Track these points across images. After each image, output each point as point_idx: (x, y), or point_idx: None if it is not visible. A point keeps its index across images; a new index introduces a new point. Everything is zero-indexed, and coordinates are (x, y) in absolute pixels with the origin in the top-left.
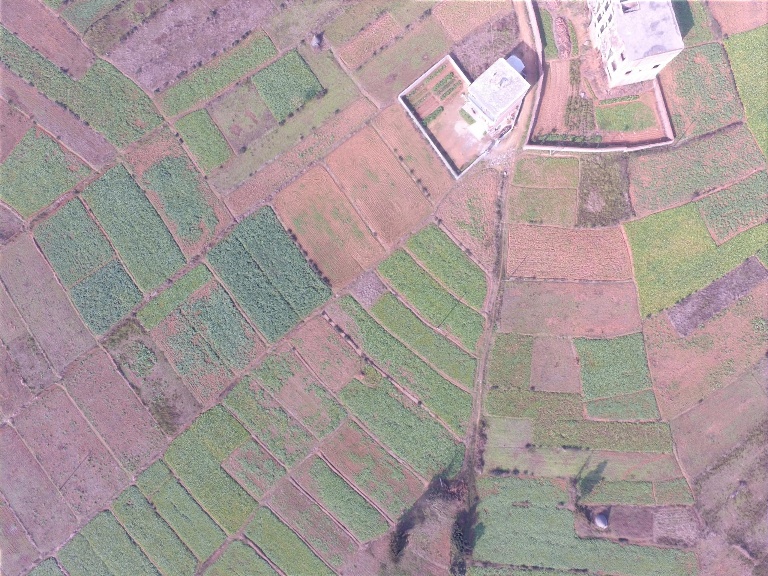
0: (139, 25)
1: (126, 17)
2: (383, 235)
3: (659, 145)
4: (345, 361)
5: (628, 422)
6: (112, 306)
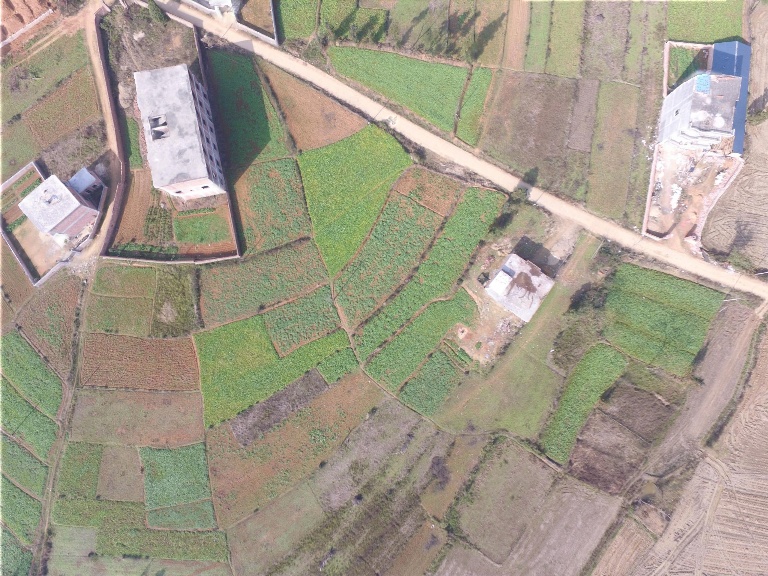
0: None
1: None
2: None
3: (228, 258)
4: None
5: (187, 531)
6: None
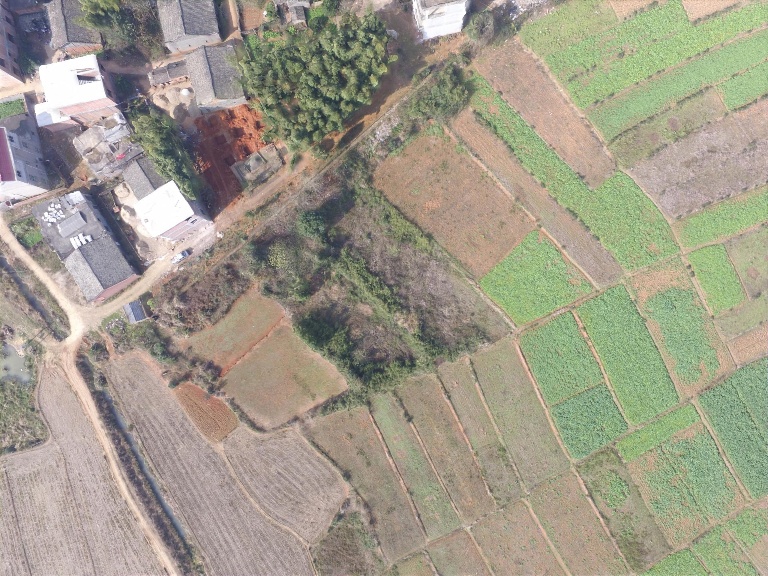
0: (670, 143)
1: (657, 132)
2: None
3: None
4: None
5: None
6: (595, 432)
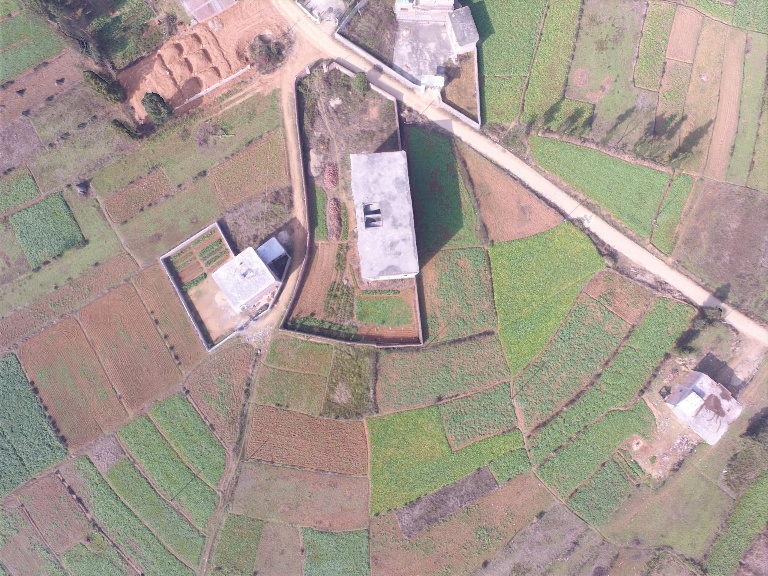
0: None
1: None
2: (128, 399)
3: (410, 345)
4: (73, 524)
5: None
6: None
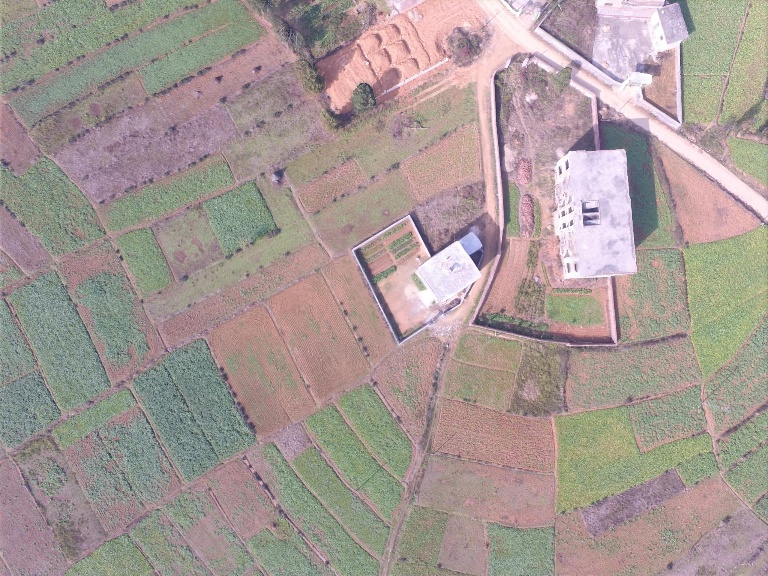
0: (92, 128)
1: (79, 117)
2: (316, 389)
3: (602, 345)
4: (259, 509)
5: None
6: (27, 420)
